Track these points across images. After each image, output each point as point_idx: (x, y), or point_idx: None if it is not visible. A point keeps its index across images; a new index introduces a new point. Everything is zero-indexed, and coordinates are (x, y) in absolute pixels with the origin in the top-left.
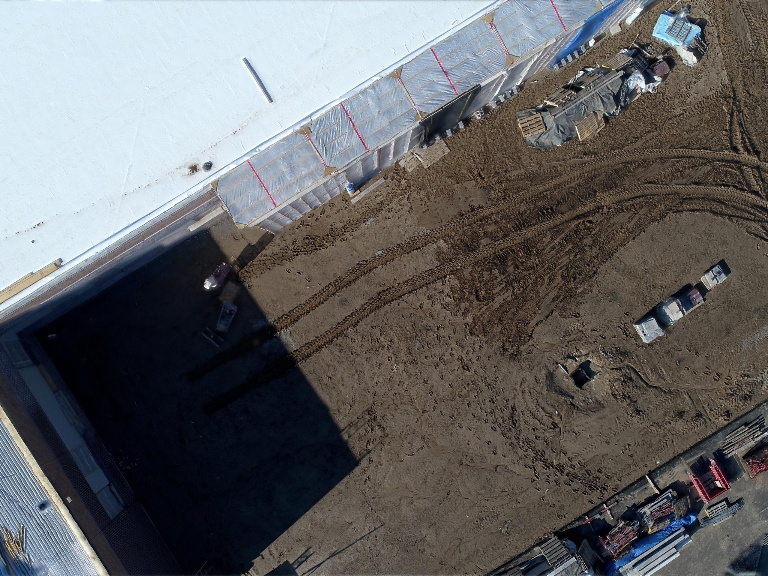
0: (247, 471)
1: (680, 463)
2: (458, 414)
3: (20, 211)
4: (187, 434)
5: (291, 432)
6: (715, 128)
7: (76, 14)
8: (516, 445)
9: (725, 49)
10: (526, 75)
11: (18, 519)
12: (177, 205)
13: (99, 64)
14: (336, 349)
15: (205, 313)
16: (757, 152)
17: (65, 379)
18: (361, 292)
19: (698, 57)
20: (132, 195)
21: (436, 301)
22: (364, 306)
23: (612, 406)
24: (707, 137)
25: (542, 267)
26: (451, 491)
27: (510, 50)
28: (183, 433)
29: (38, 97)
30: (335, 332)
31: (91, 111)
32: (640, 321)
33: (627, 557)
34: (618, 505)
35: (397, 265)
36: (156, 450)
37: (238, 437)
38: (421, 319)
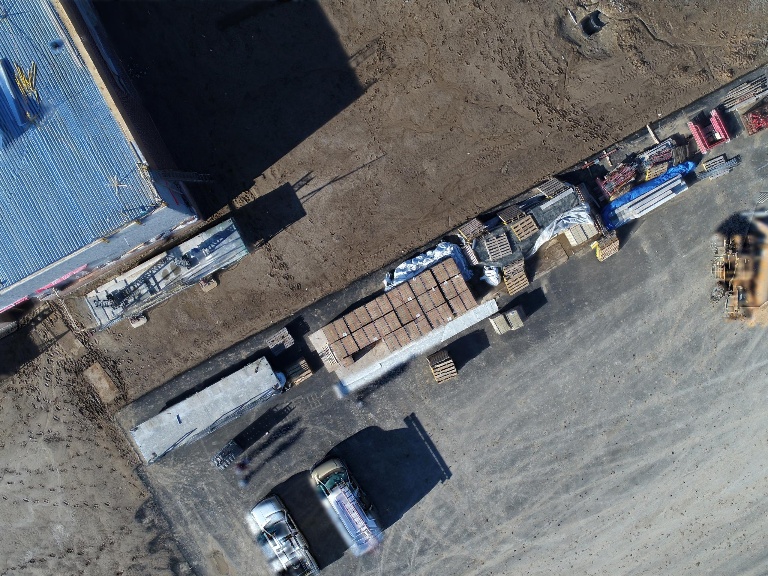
0: (254, 90)
1: (681, 116)
2: (466, 51)
3: None
4: (198, 47)
5: (300, 55)
6: None
7: None
8: (521, 86)
9: None
10: None
11: (29, 56)
12: None
13: None
14: None
15: None
16: None
17: None
18: None
19: None
20: None
21: None
22: None
23: (618, 55)
24: None
25: None
26: (454, 127)
27: None
28: (194, 46)
29: None
30: None
31: None
32: None
33: (623, 197)
34: (617, 153)
35: None
36: (166, 60)
37: (248, 55)
38: None
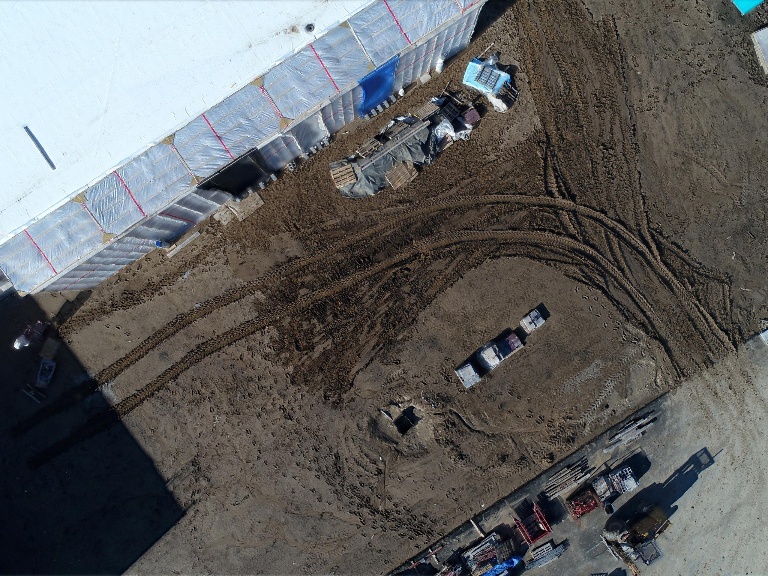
0: (73, 524)
1: (504, 506)
2: (282, 463)
3: None
4: (12, 490)
5: (116, 485)
6: (530, 173)
7: None
8: (340, 492)
9: (536, 95)
10: (332, 128)
11: None
12: None
13: None
14: (158, 402)
15: (26, 370)
16: (573, 196)
17: None
18: (181, 345)
19: (509, 103)
20: None
21: (256, 352)
22: (184, 359)
23: (435, 451)
24: (522, 182)
25: (361, 315)
26: (277, 539)
27: (284, 113)
28: (8, 489)
29: None
30: (156, 385)
31: None
32: (460, 366)
33: None
34: (443, 549)
35: (215, 317)
36: None
37: (63, 491)
38: (242, 370)
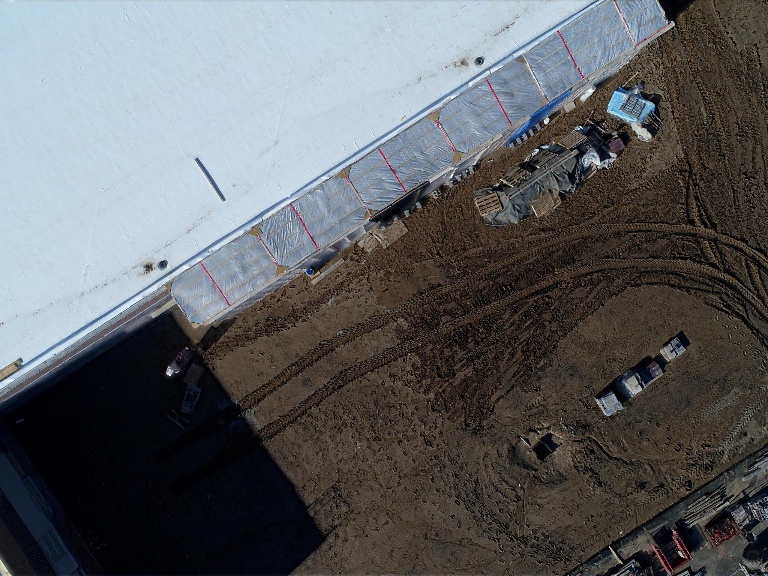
0: (215, 549)
1: (643, 533)
2: (422, 489)
3: None
4: (155, 514)
5: (257, 510)
6: (671, 202)
7: (30, 120)
8: (480, 518)
9: (680, 124)
10: (481, 157)
11: None
12: (133, 306)
13: (54, 168)
14: (300, 428)
15: (170, 395)
16: (714, 224)
17: (34, 463)
18: (323, 371)
19: (653, 132)
20: (89, 295)
21: (398, 379)
22: (327, 385)
23: (574, 478)
24: (664, 211)
25: (502, 343)
26: (416, 565)
27: (457, 147)
28: (151, 513)
29: None
30: (299, 411)
31: (47, 214)
32: (600, 394)
33: None
34: (582, 575)
35: (358, 344)
36: (125, 530)
37: (205, 516)
38: (383, 396)
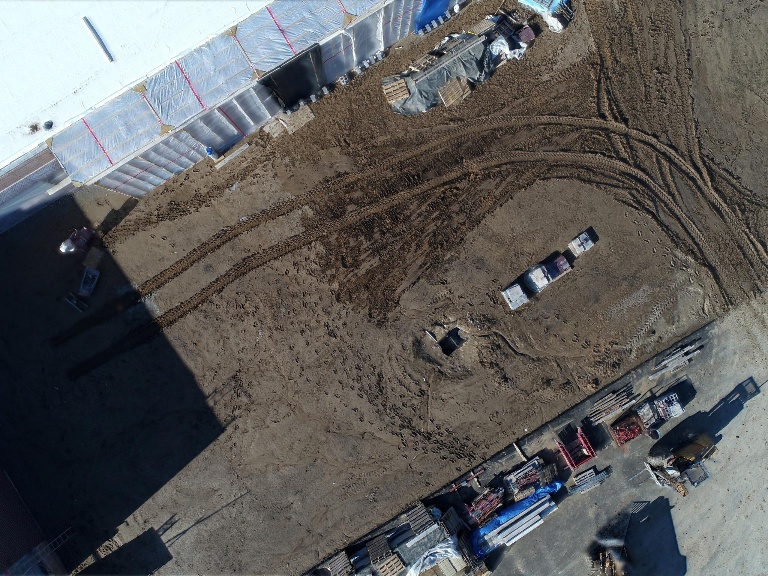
0: (112, 437)
1: (548, 431)
2: (324, 381)
3: None
4: (51, 400)
5: (156, 398)
6: (582, 95)
7: None
8: (383, 412)
9: (592, 16)
10: (387, 40)
11: None
12: (13, 163)
13: None
14: (201, 315)
15: (69, 278)
16: (625, 119)
17: None
18: (226, 258)
19: (564, 23)
20: None
21: (302, 267)
22: (229, 272)
23: (480, 373)
24: (574, 104)
25: (409, 234)
26: (318, 458)
27: (347, 9)
28: (47, 399)
29: None
30: (200, 298)
31: None
32: (507, 288)
33: (492, 524)
34: (485, 473)
35: (262, 231)
36: (20, 416)
37: (102, 403)
38: (287, 285)
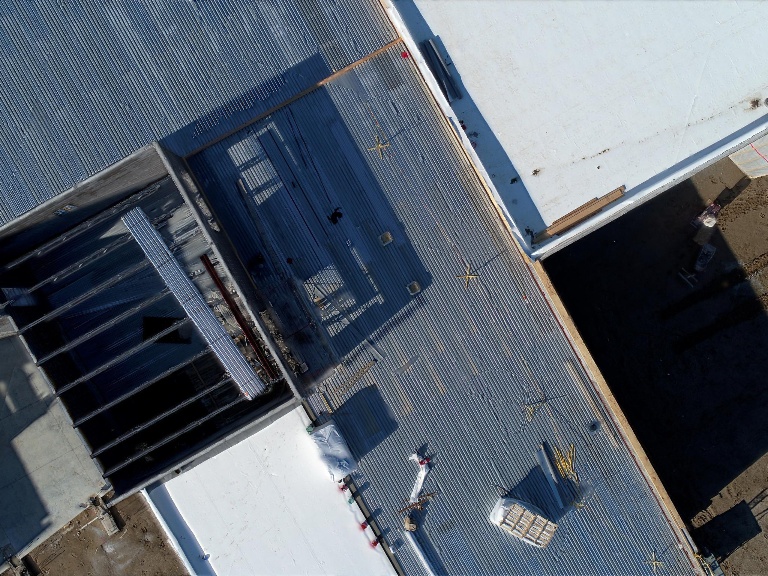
0: (710, 411)
1: None
2: None
3: (588, 137)
4: (656, 372)
5: (754, 374)
6: None
7: None
8: None
9: None
10: None
11: (568, 439)
12: (753, 137)
13: None
14: None
15: (680, 254)
16: None
17: None
18: None
19: None
20: (696, 126)
21: None
22: None
23: None
24: None
25: None
26: None
27: None
28: (652, 370)
29: (614, 26)
30: None
31: (663, 42)
32: None
33: None
34: None
35: None
36: (625, 386)
37: (704, 377)
38: None
